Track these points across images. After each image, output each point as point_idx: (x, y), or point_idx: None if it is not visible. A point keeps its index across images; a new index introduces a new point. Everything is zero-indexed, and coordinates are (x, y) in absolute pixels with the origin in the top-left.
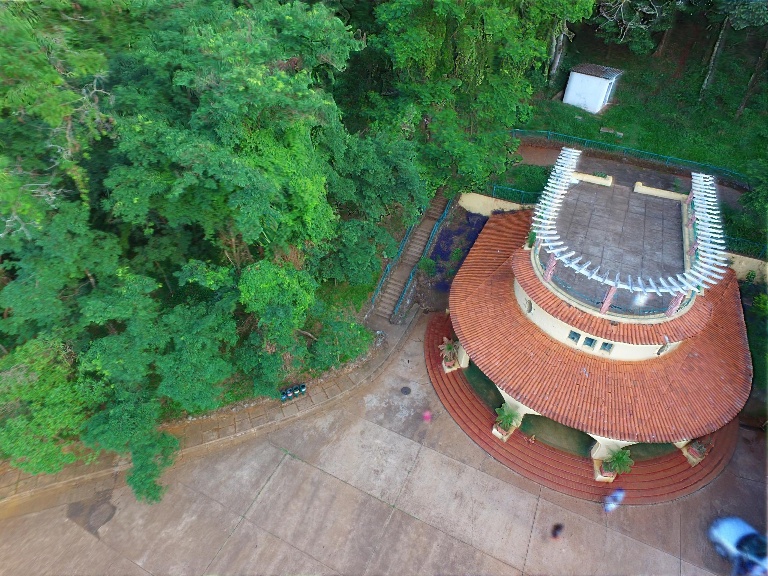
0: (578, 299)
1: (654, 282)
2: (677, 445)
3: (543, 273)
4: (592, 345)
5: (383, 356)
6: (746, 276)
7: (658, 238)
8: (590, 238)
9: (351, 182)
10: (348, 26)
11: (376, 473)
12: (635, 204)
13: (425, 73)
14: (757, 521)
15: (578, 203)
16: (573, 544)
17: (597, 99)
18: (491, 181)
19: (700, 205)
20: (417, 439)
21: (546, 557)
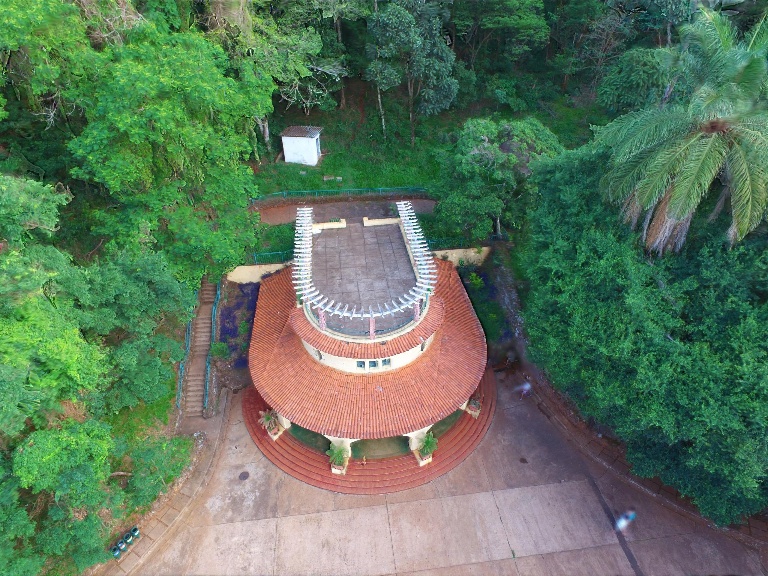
0: (352, 335)
1: (396, 303)
2: (462, 408)
3: (318, 324)
4: (376, 365)
5: (209, 454)
6: (459, 263)
7: (392, 260)
8: (345, 278)
9: (108, 310)
10: (46, 186)
11: (244, 570)
12: (368, 236)
13: (146, 186)
14: (525, 435)
15: (327, 250)
16: (423, 526)
17: (311, 154)
18: (250, 250)
19: (408, 228)
20: (271, 515)
21: (408, 550)
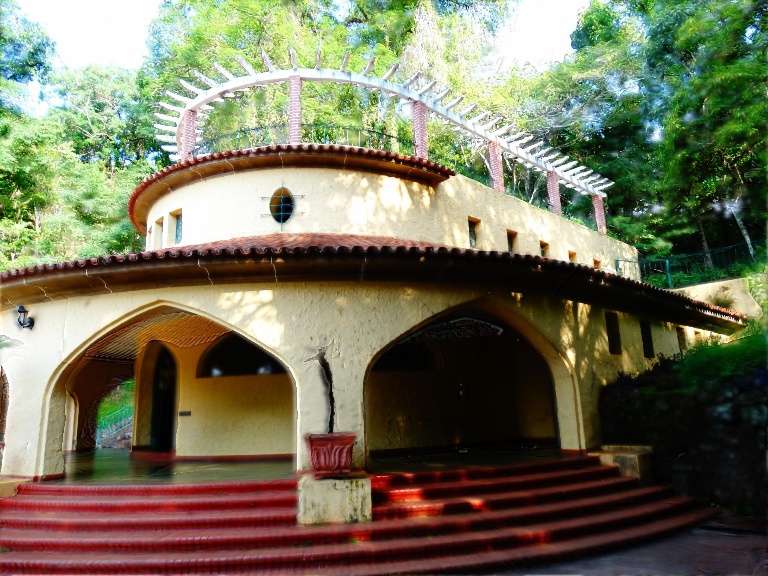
0: None
1: None
2: None
3: None
4: None
5: None
6: None
7: None
8: None
9: (69, 216)
10: None
11: None
12: None
13: None
14: None
15: None
16: None
17: None
18: None
19: None
20: None
21: None
